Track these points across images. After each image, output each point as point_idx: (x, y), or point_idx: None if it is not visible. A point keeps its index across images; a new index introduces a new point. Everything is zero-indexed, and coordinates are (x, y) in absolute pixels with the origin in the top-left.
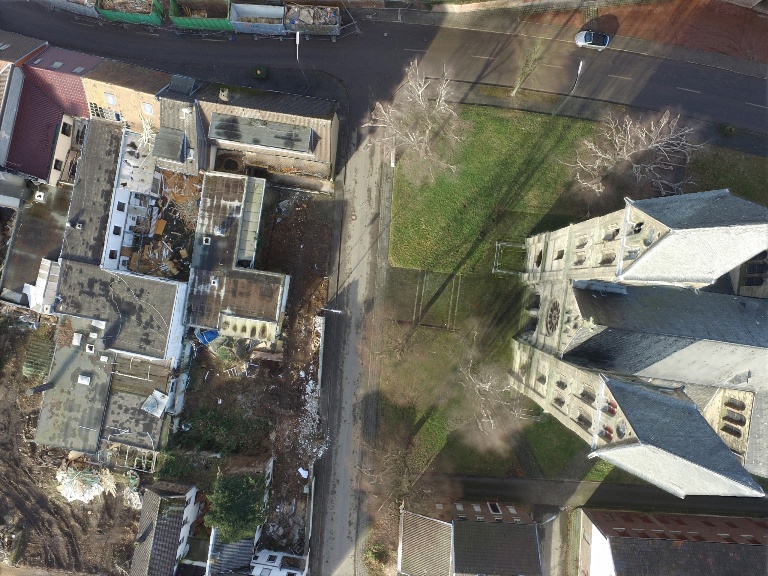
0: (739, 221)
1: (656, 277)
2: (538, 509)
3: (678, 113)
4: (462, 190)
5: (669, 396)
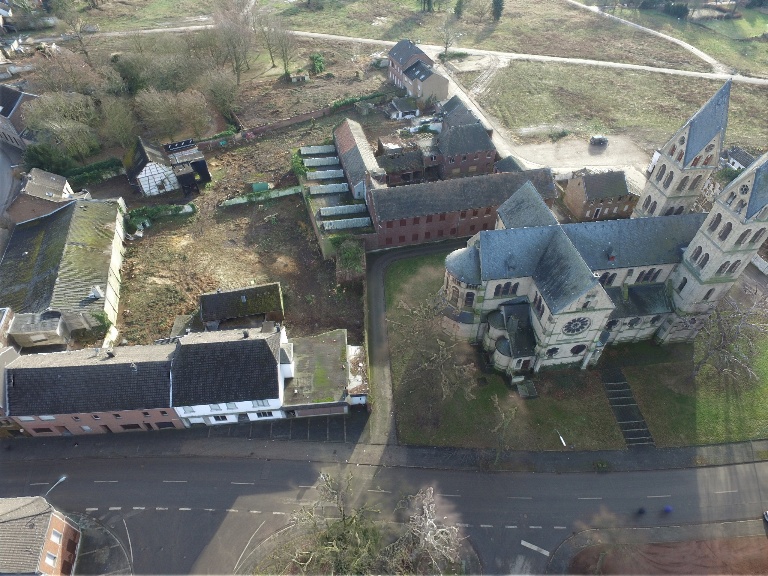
0: None
1: None
2: (569, 221)
3: (652, 472)
4: (764, 362)
5: None
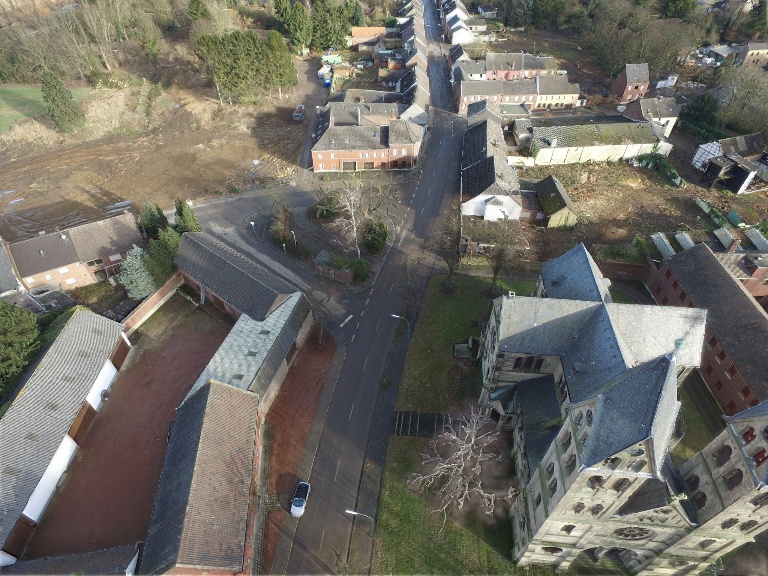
0: (654, 390)
1: (665, 445)
2: None
3: (371, 419)
4: None
5: (761, 430)
